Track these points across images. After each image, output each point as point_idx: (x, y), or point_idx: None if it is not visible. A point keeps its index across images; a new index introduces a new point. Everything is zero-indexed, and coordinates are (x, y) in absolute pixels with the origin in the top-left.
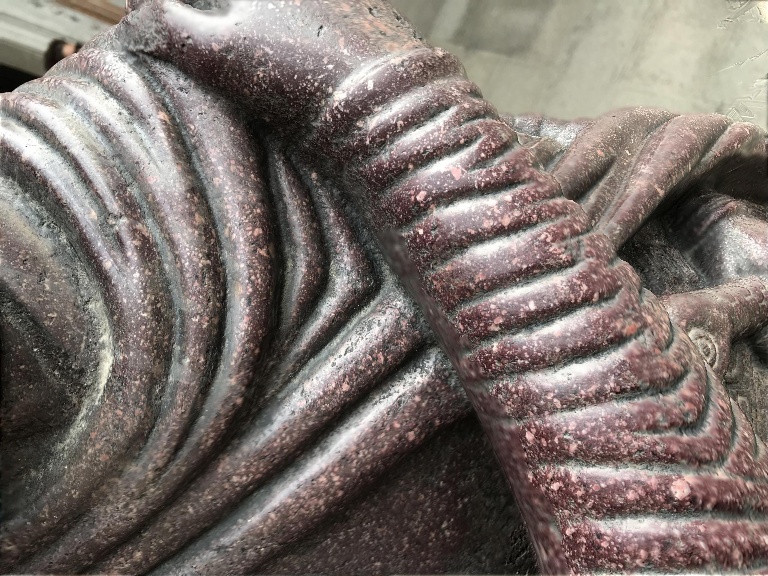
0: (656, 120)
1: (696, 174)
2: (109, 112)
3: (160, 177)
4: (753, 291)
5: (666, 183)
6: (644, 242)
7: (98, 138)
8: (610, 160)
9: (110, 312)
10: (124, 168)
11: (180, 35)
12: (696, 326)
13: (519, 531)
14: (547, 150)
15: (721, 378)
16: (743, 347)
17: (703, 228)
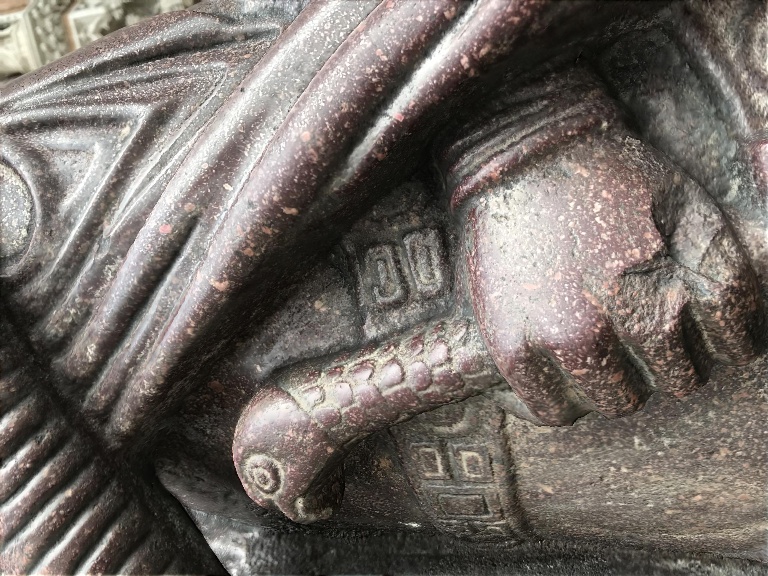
0: (349, 23)
1: (338, 188)
2: None
3: None
4: (414, 374)
5: (230, 268)
6: (365, 239)
7: None
8: (183, 230)
9: None
10: None
11: None
12: (256, 453)
13: (251, 506)
14: (135, 221)
15: (286, 502)
16: (477, 398)
17: (451, 209)
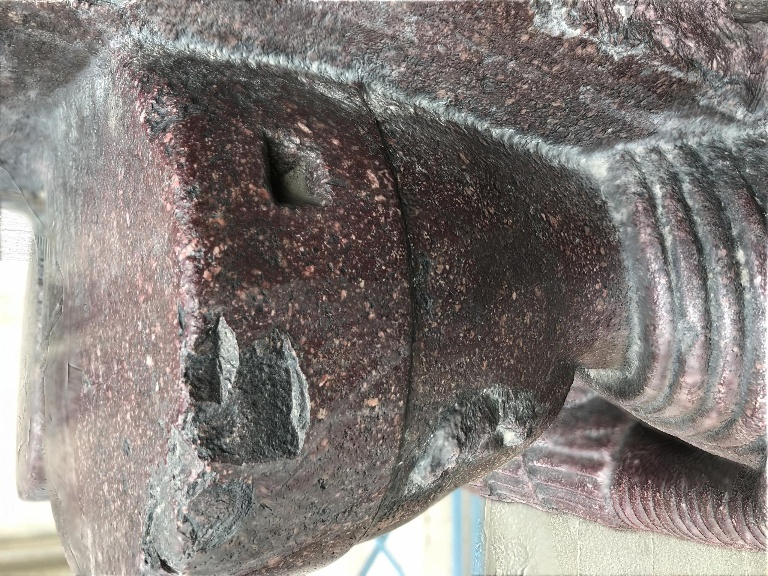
0: None
1: None
2: (708, 427)
3: (682, 436)
4: None
5: None
6: None
7: (688, 415)
8: None
9: (606, 389)
10: (678, 420)
11: (767, 495)
12: None
13: None
14: None
15: None
16: None
17: None
